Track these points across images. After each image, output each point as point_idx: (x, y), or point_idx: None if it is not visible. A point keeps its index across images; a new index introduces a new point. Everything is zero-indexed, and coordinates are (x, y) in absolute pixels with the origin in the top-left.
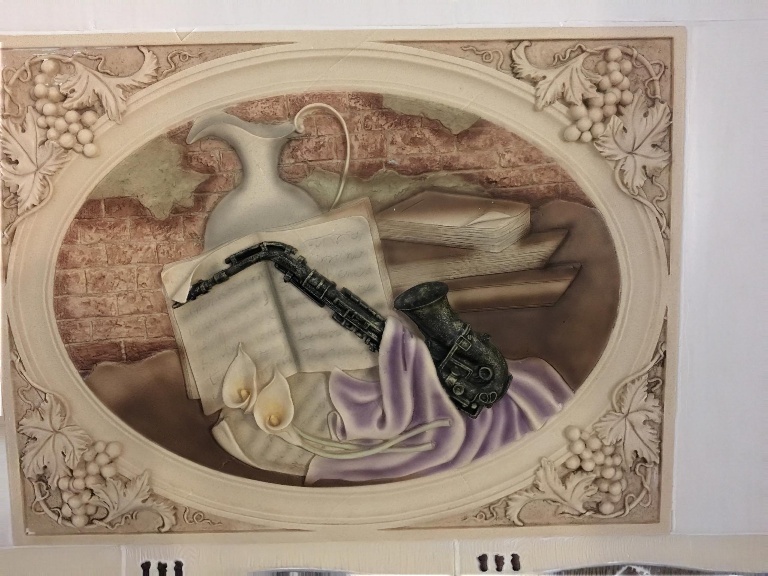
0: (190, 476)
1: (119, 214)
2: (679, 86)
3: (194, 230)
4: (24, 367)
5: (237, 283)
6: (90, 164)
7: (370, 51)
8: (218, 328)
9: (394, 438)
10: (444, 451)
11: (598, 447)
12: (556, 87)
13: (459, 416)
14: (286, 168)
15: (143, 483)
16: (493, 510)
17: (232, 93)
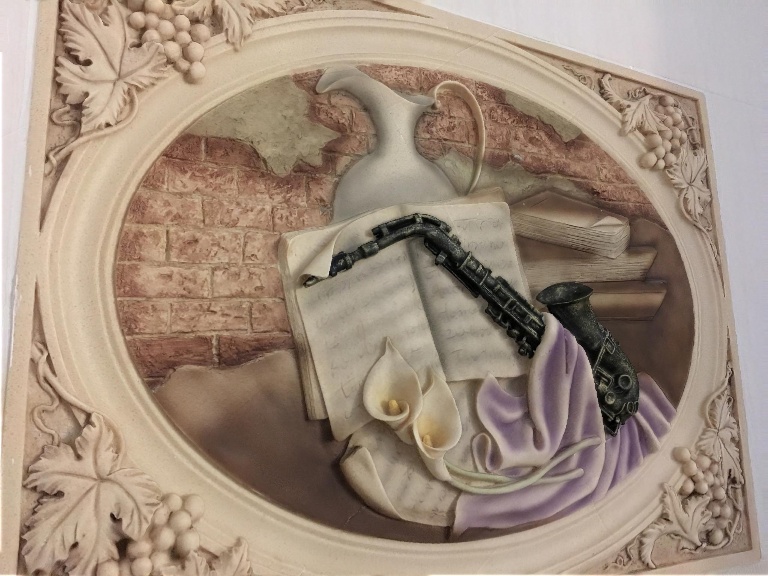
0: (298, 544)
1: (225, 160)
2: (708, 138)
3: (321, 195)
4: (53, 369)
5: (381, 262)
6: (187, 92)
7: (495, 46)
8: (356, 319)
9: (547, 463)
10: (586, 480)
11: (708, 465)
12: (638, 116)
13: (604, 433)
14: (422, 142)
15: (242, 557)
16: (629, 552)
17: (365, 51)
